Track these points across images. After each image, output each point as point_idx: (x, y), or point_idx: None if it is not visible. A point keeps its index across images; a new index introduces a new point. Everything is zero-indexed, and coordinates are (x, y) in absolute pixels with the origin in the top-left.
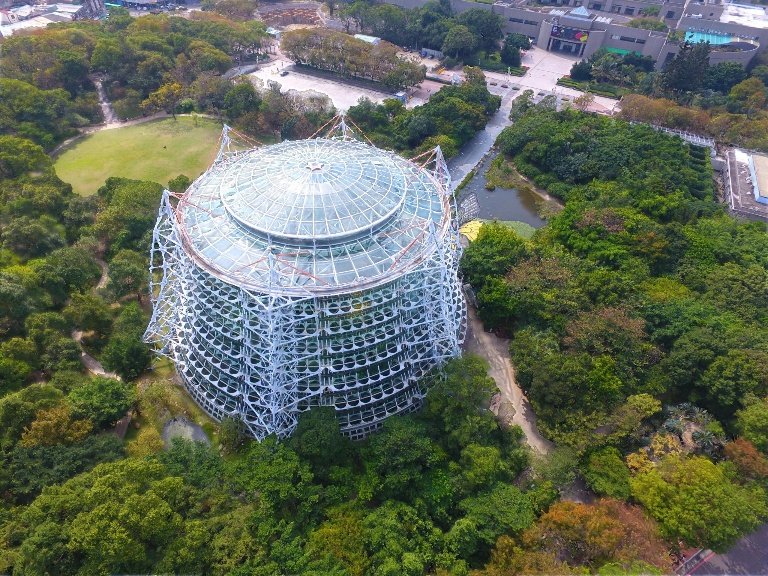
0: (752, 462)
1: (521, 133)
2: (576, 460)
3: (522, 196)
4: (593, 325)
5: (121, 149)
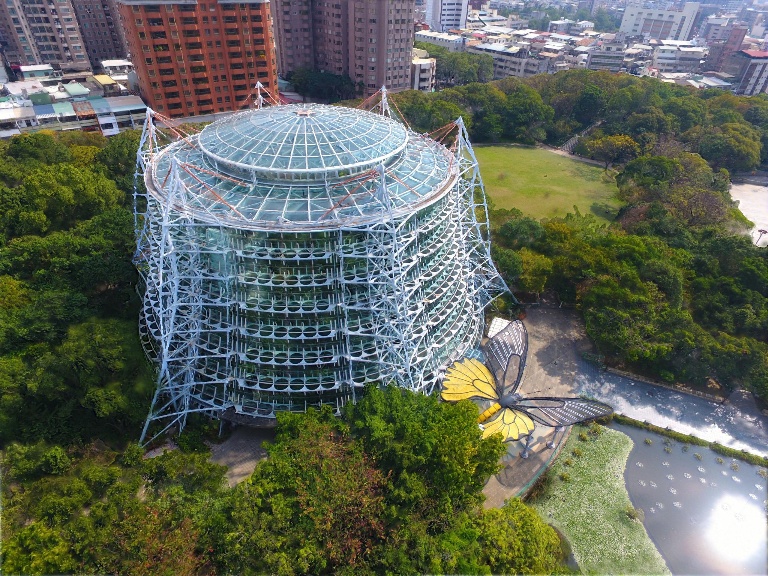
0: None
1: None
2: None
3: None
4: (163, 567)
5: (524, 162)
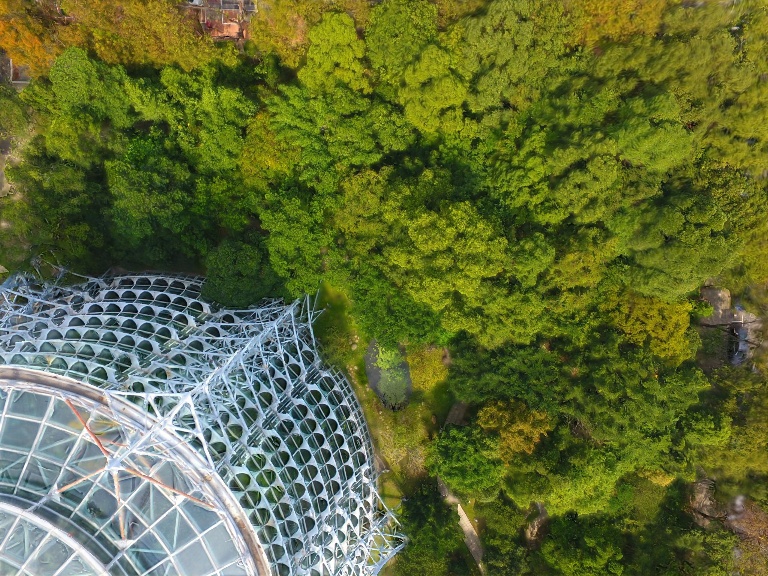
0: None
1: None
2: None
3: None
4: None
5: None
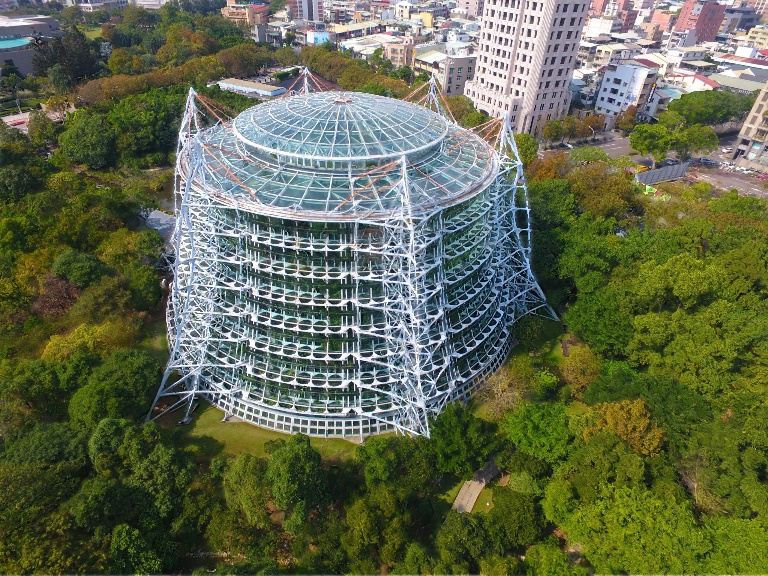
0: (497, 132)
1: (99, 138)
2: (505, 175)
3: None
4: None
5: None
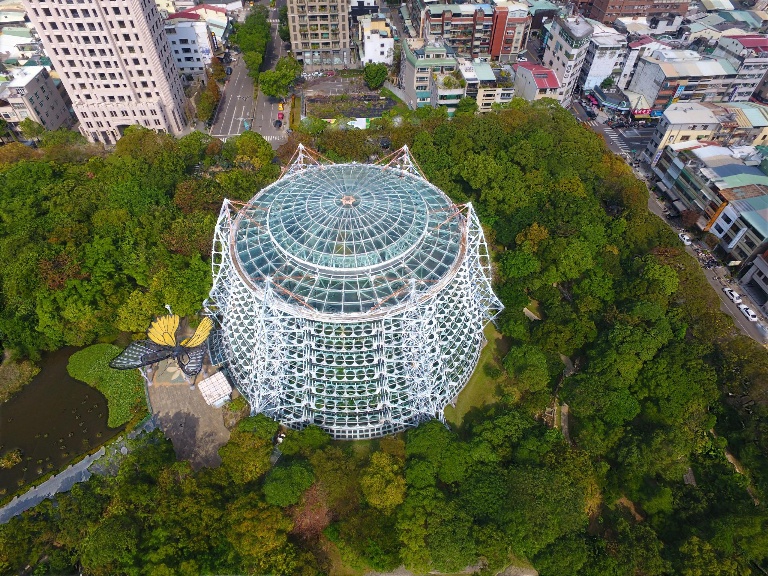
0: (218, 143)
1: None
2: None
3: (1, 422)
4: None
5: None
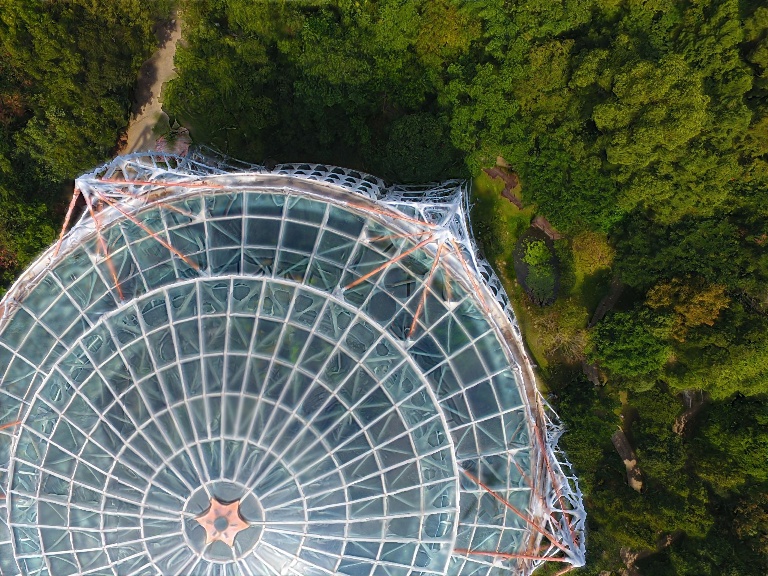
0: None
1: None
2: None
3: None
4: None
5: None
